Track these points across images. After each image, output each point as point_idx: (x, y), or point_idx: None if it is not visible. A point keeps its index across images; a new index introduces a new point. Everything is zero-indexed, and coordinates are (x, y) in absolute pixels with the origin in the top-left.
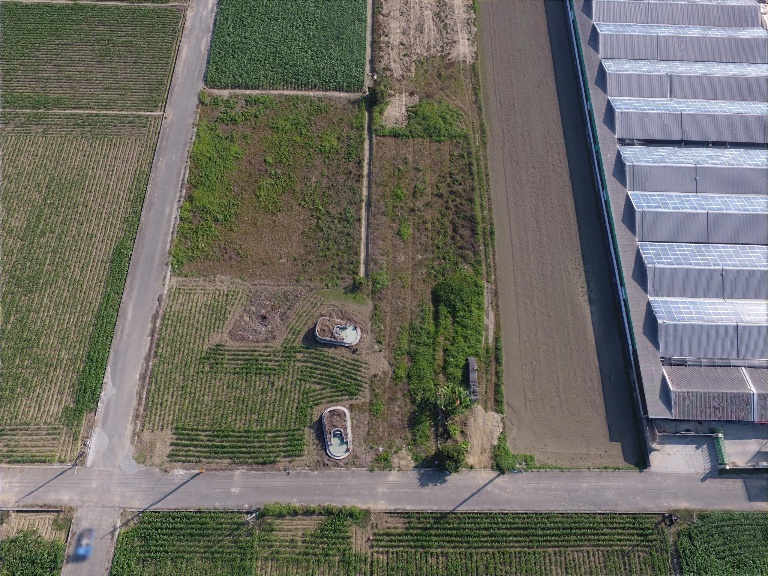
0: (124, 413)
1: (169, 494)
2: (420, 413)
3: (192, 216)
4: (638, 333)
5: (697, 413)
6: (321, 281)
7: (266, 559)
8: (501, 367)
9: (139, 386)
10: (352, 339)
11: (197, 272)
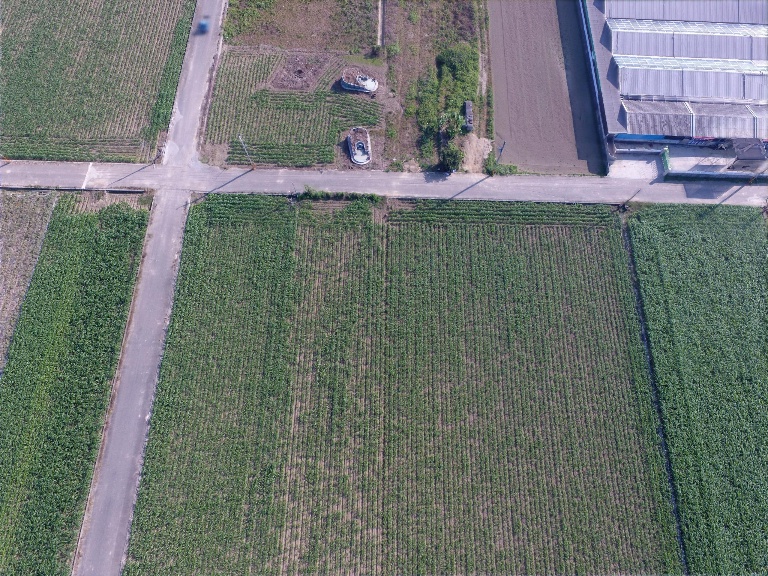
0: (190, 131)
1: (228, 183)
2: (426, 137)
3: (239, 3)
4: (603, 79)
5: (647, 130)
6: (346, 49)
7: (305, 226)
8: (492, 109)
9: (201, 114)
10: (371, 87)
11: (244, 42)
